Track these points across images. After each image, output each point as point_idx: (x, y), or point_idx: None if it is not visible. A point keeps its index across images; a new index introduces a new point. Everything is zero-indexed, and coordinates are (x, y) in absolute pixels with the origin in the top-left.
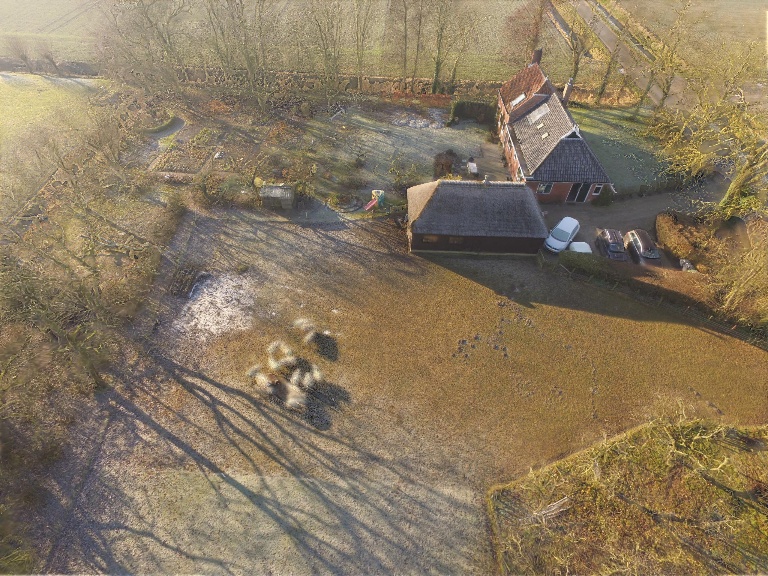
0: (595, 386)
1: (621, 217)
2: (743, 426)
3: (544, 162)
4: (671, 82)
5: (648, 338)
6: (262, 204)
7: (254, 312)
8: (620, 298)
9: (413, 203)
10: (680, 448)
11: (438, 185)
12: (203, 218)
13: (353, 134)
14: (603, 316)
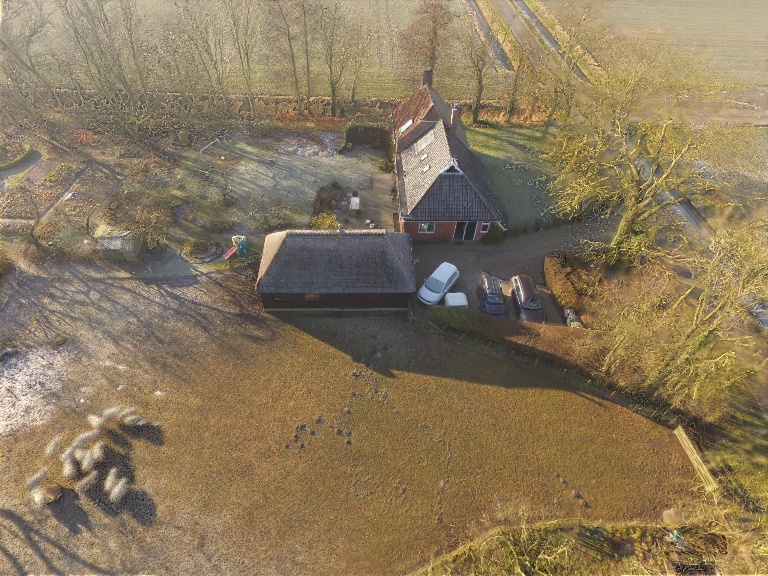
0: (447, 478)
1: (511, 257)
2: (610, 522)
3: (422, 200)
4: (571, 103)
5: (518, 410)
6: (103, 257)
7: (58, 400)
8: (494, 359)
9: (265, 255)
10: (524, 567)
11: (286, 237)
12: (29, 277)
13: (232, 165)
14: (471, 384)
